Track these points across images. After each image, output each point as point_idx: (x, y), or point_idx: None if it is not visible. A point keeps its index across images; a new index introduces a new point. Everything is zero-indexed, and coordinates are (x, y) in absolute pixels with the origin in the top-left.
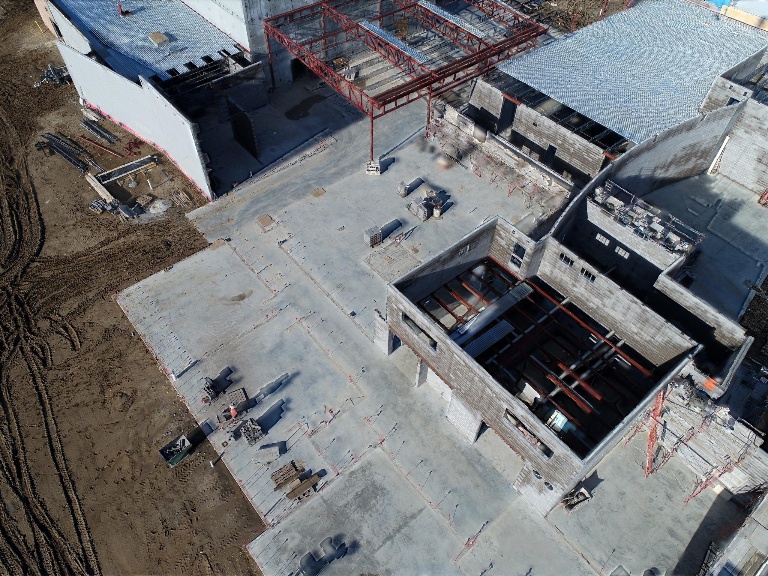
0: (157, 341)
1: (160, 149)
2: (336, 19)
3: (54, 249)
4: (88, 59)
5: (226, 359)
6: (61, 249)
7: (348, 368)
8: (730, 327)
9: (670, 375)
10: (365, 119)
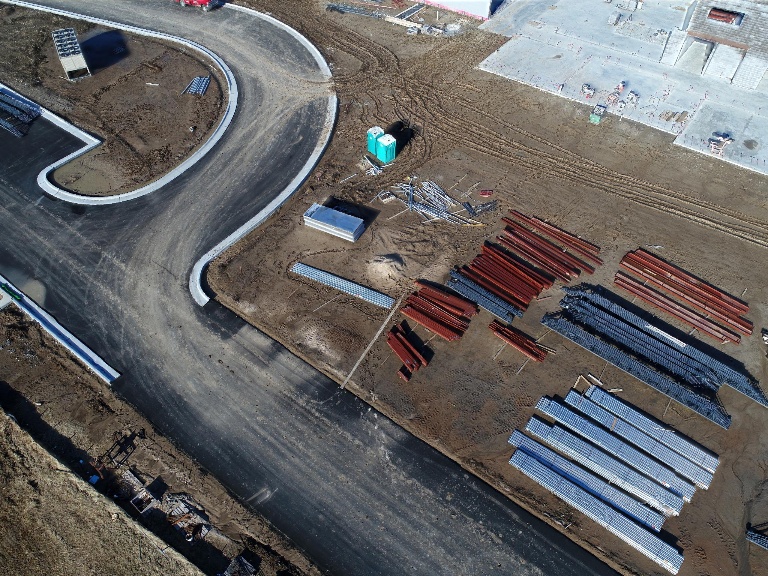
0: (529, 80)
1: (419, 1)
2: None
3: (405, 55)
4: None
5: (580, 81)
6: (410, 54)
7: (656, 74)
8: None
9: None
10: None
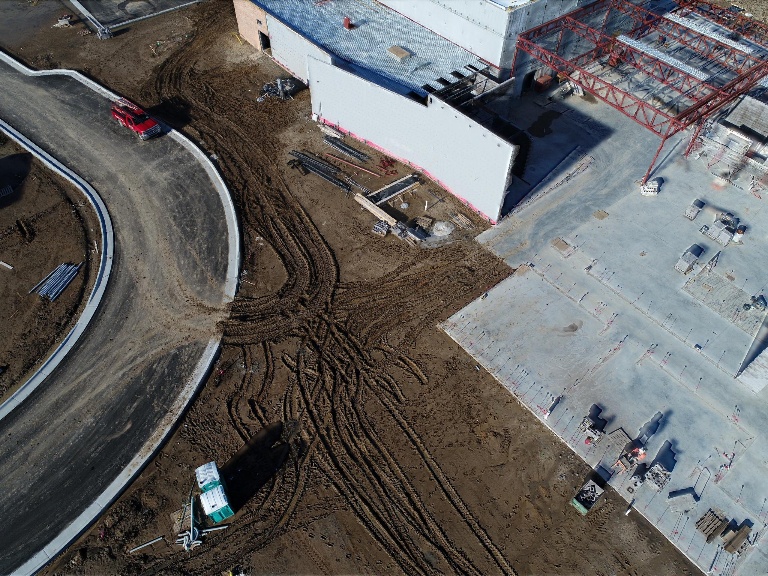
0: (508, 375)
1: (416, 168)
2: (570, 32)
3: (353, 274)
4: (352, 75)
5: (589, 396)
6: (360, 274)
7: (721, 407)
8: None
9: None
10: (612, 136)
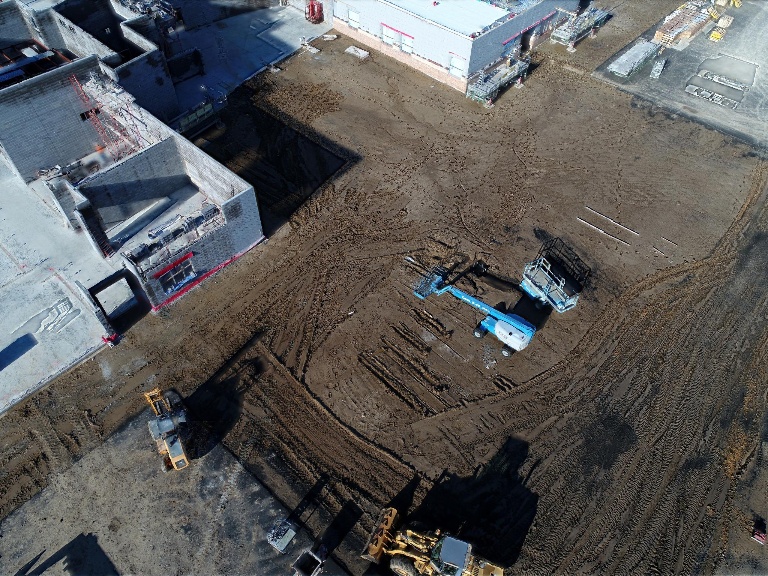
0: None
1: None
2: None
3: None
4: None
5: None
6: None
7: None
8: (152, 47)
9: (73, 62)
10: None
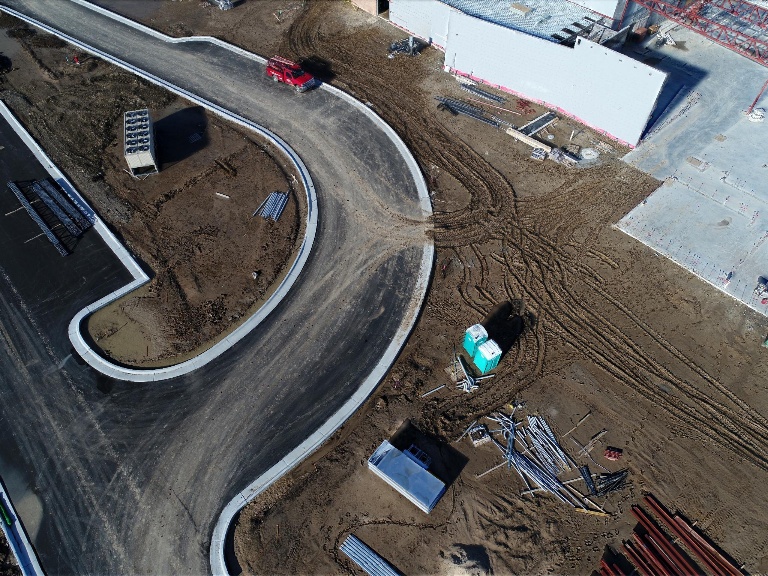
0: (684, 259)
1: (550, 107)
2: None
3: (526, 191)
4: (497, 26)
5: (754, 270)
6: (532, 191)
7: None
8: None
9: None
10: (711, 77)
